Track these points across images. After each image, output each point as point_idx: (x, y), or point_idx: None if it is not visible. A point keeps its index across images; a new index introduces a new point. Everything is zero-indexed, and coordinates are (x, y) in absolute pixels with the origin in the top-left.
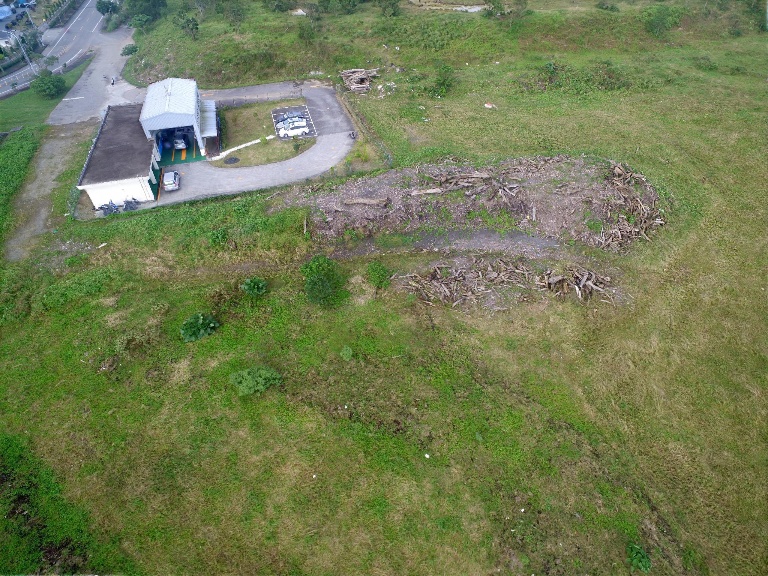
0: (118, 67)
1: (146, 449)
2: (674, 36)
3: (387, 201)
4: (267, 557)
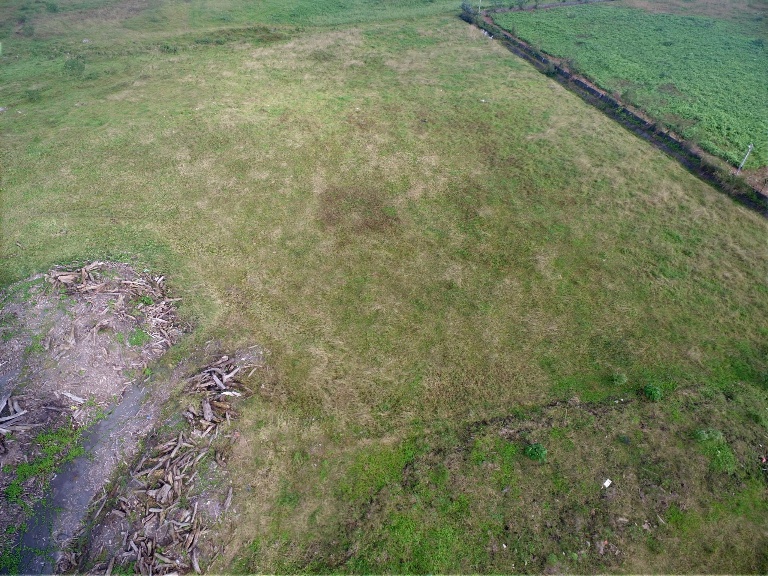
0: None
1: None
2: None
3: None
4: None
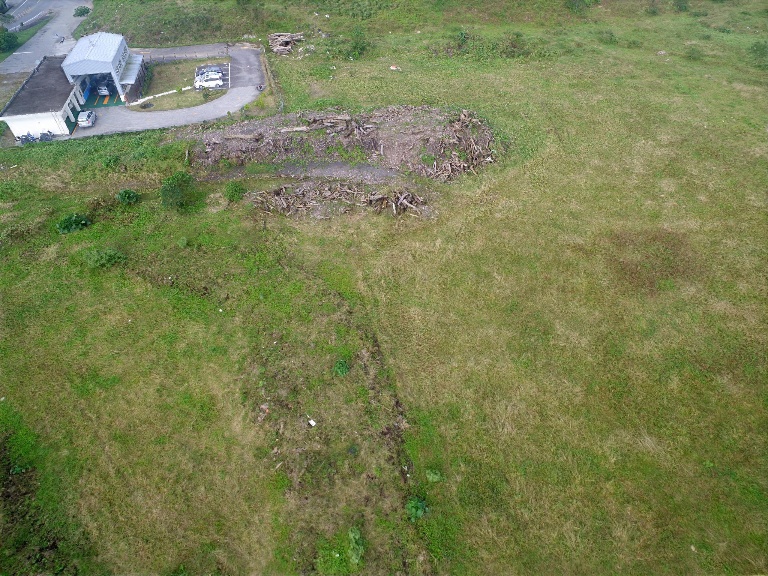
0: (71, 27)
1: (7, 301)
2: (592, 13)
3: (259, 136)
4: (76, 366)
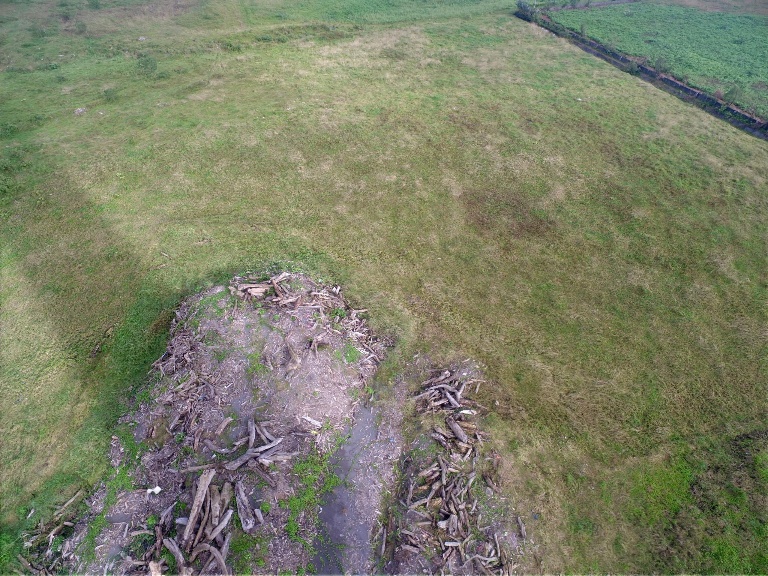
0: None
1: None
2: None
3: None
4: None
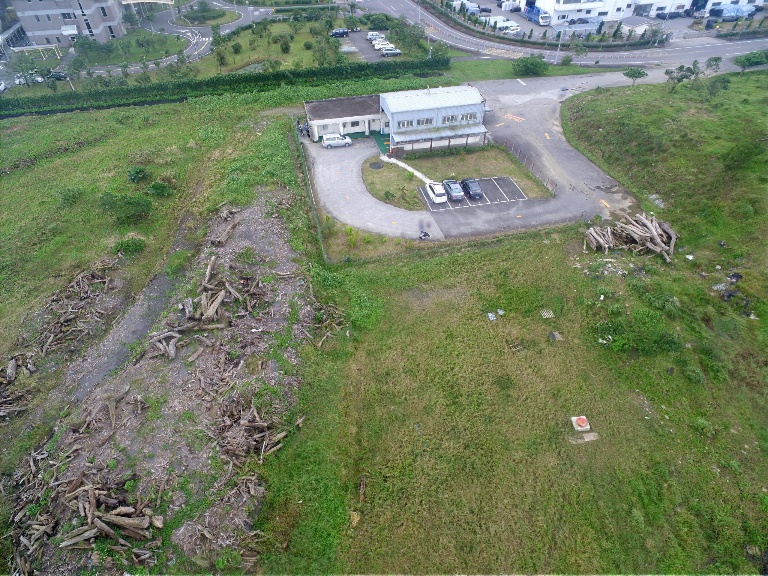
0: (616, 84)
1: None
2: None
3: (217, 242)
4: None
